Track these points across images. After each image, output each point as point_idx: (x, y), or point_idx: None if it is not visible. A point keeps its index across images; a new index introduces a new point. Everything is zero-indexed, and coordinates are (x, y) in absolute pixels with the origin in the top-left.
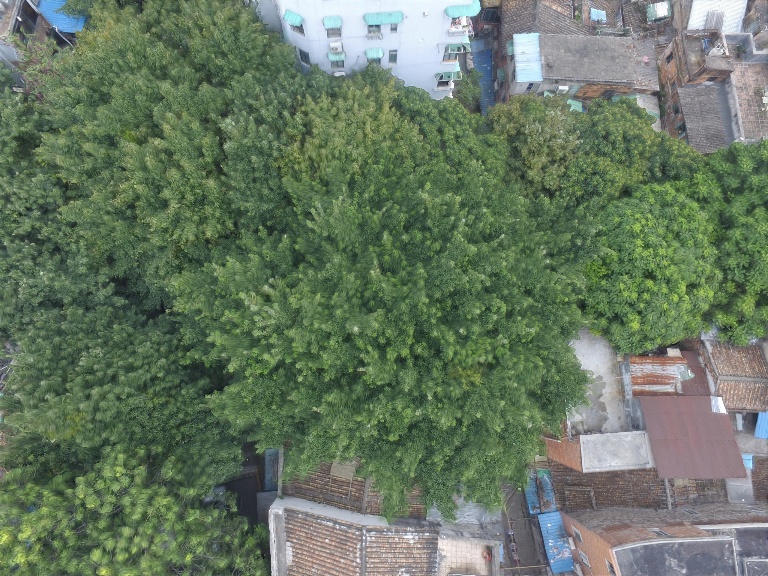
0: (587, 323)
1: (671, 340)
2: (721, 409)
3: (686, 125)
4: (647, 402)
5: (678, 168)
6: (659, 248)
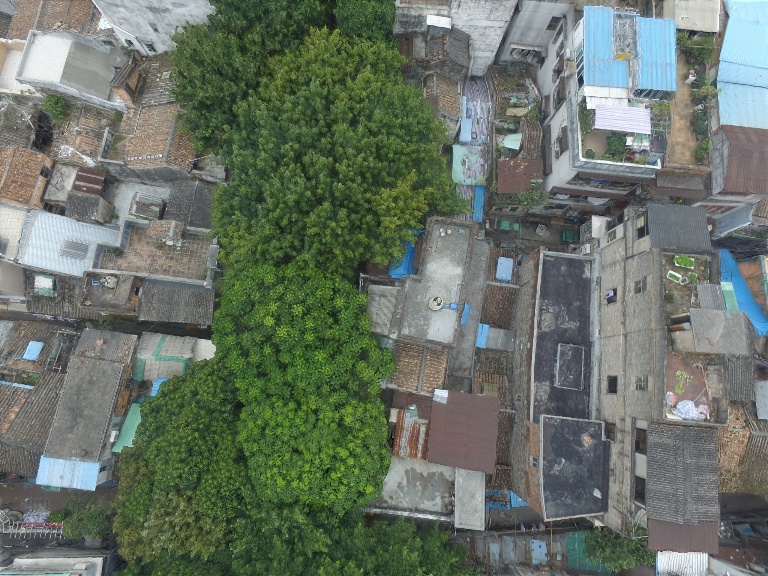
0: (361, 533)
1: (383, 432)
2: (444, 395)
3: (180, 322)
4: (433, 459)
5: (226, 391)
6: (303, 470)
